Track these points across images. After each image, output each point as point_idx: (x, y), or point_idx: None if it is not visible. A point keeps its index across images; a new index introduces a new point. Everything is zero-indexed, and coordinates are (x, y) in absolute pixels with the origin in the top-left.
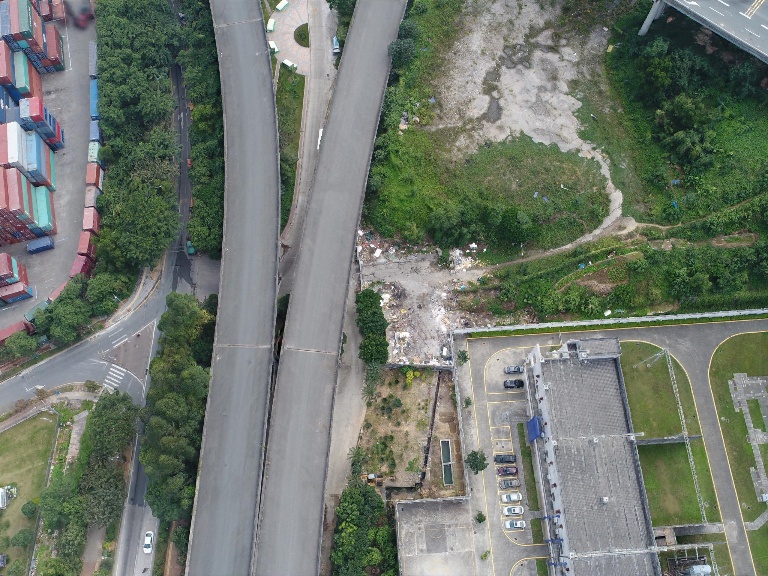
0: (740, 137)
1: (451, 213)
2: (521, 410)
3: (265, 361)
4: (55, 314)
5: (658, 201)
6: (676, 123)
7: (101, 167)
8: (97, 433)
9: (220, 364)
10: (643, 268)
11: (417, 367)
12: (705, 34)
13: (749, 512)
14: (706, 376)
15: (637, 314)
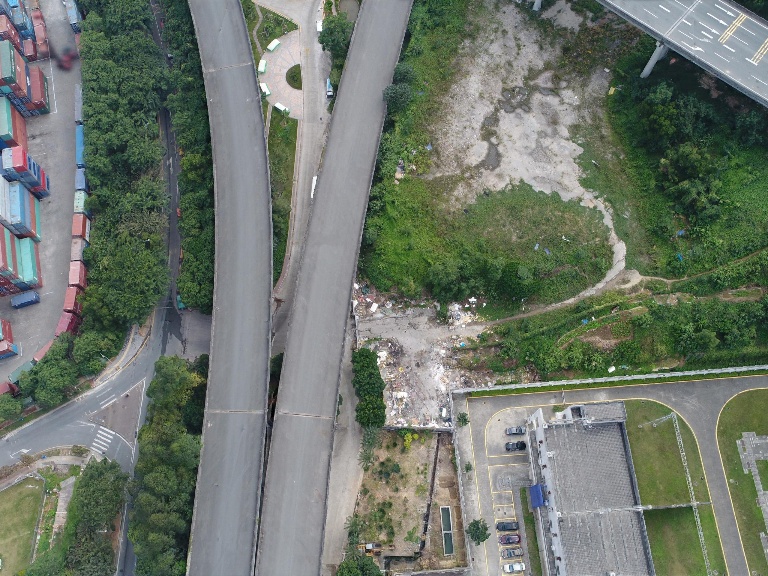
0: (747, 187)
1: (449, 269)
2: (523, 474)
3: (258, 427)
4: (40, 377)
5: (663, 253)
6: (681, 171)
7: (87, 217)
8: (84, 504)
9: (211, 431)
10: (648, 324)
11: (416, 429)
12: (709, 77)
13: None
14: (714, 435)
15: (642, 370)
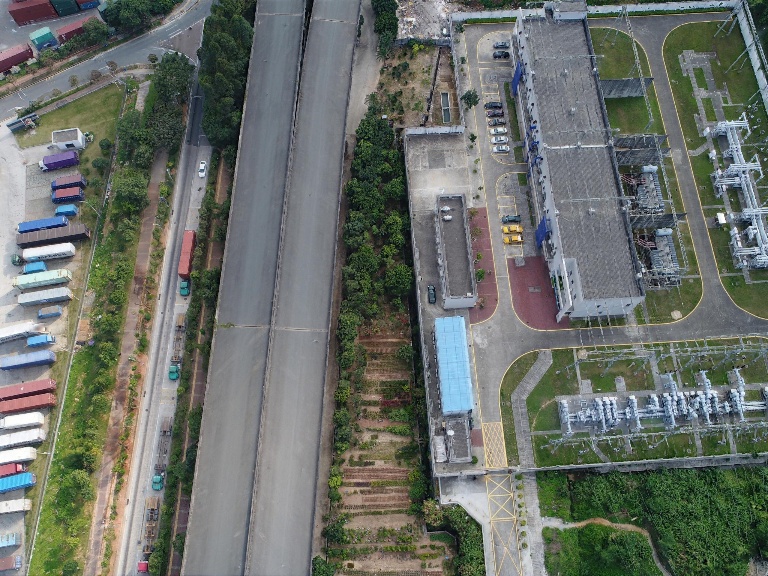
0: None
1: None
2: (507, 74)
3: (298, 24)
4: (124, 1)
5: None
6: None
7: None
8: (161, 80)
9: (261, 27)
10: None
11: (422, 41)
12: None
13: (692, 143)
14: (660, 52)
15: None
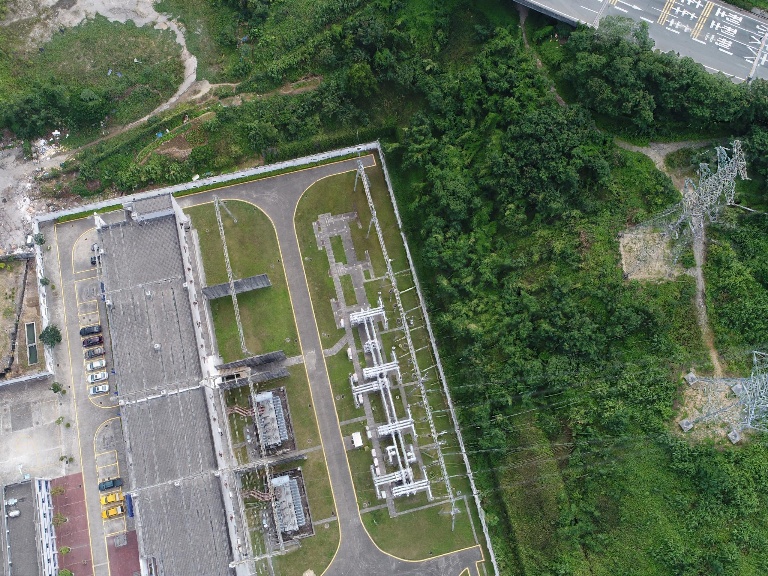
0: None
1: (12, 101)
2: None
3: None
4: None
5: (230, 60)
6: None
7: None
8: None
9: None
10: (216, 127)
11: (1, 259)
12: None
13: (328, 340)
14: (291, 222)
15: None
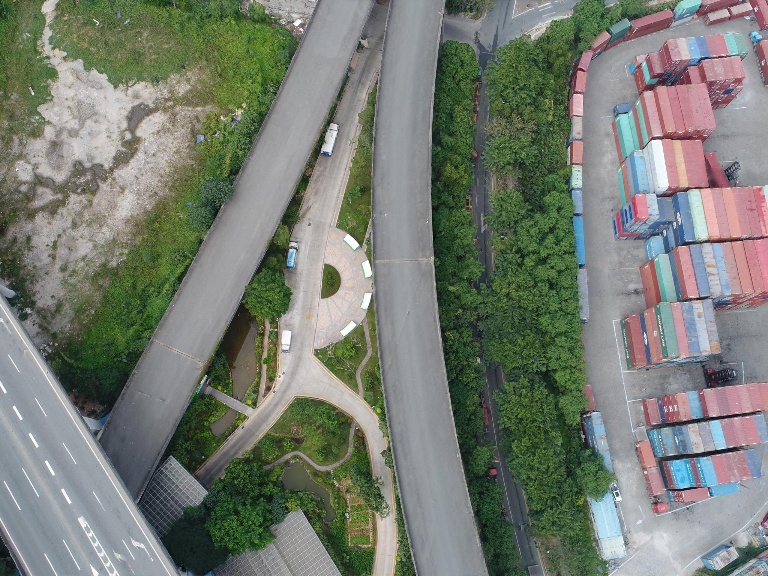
0: None
1: None
2: None
3: None
4: (602, 7)
5: None
6: None
7: None
8: None
9: None
10: None
11: None
12: None
13: None
14: None
15: None
